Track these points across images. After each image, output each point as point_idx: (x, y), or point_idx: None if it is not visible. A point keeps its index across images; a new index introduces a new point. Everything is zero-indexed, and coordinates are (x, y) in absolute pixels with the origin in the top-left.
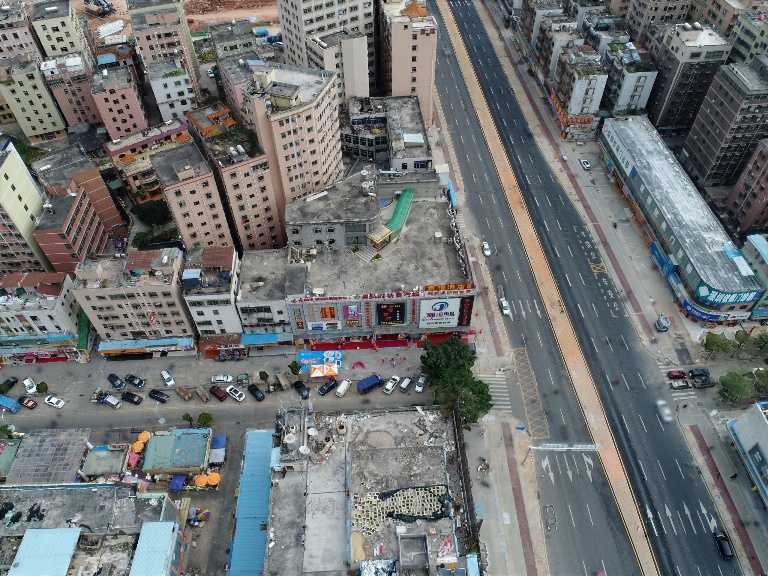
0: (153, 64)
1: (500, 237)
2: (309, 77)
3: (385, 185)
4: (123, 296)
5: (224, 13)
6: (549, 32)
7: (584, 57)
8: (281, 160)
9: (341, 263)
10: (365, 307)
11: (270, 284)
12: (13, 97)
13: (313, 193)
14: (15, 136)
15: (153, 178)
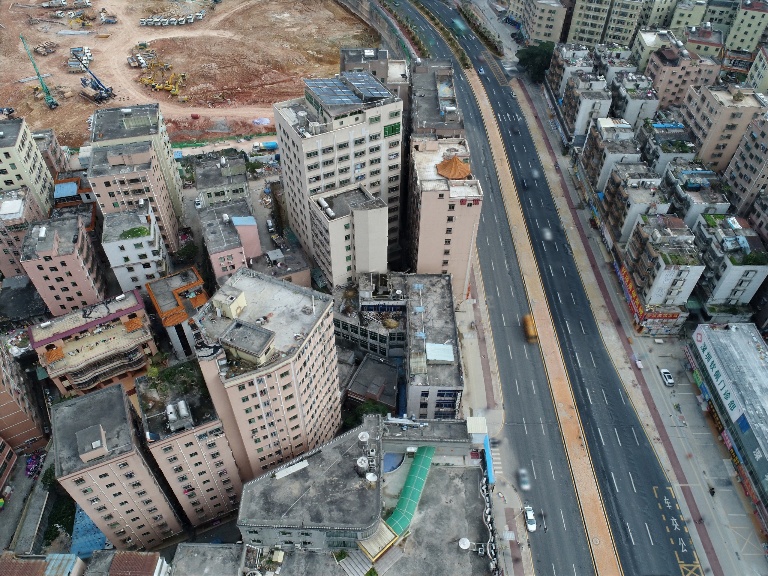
0: (113, 214)
1: (550, 497)
2: (295, 299)
3: (394, 441)
4: None
5: (235, 109)
6: (624, 188)
7: (673, 237)
8: (242, 424)
9: None
10: None
11: None
12: None
13: (287, 464)
14: None
15: (89, 376)
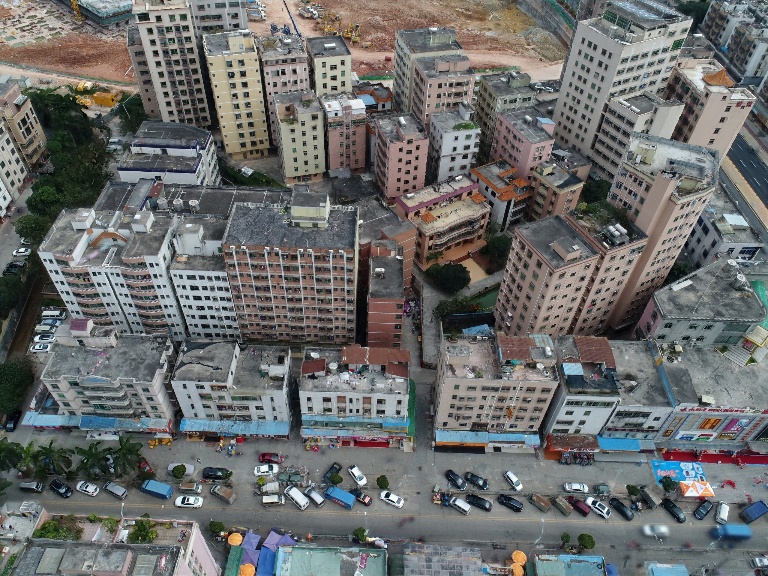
0: (437, 113)
1: None
2: (685, 153)
3: None
4: (497, 388)
5: None
6: None
7: None
8: (658, 244)
9: (712, 365)
10: (756, 422)
11: (645, 385)
12: (290, 136)
13: (677, 281)
14: (266, 174)
15: (445, 238)
